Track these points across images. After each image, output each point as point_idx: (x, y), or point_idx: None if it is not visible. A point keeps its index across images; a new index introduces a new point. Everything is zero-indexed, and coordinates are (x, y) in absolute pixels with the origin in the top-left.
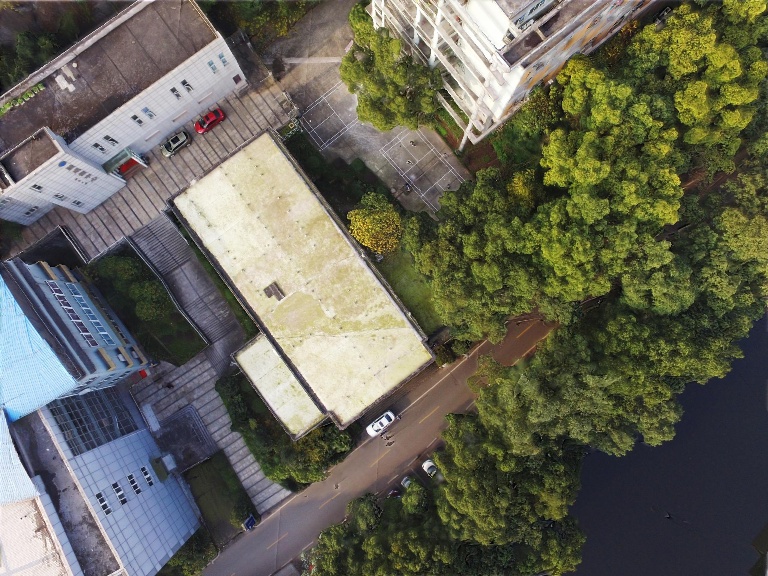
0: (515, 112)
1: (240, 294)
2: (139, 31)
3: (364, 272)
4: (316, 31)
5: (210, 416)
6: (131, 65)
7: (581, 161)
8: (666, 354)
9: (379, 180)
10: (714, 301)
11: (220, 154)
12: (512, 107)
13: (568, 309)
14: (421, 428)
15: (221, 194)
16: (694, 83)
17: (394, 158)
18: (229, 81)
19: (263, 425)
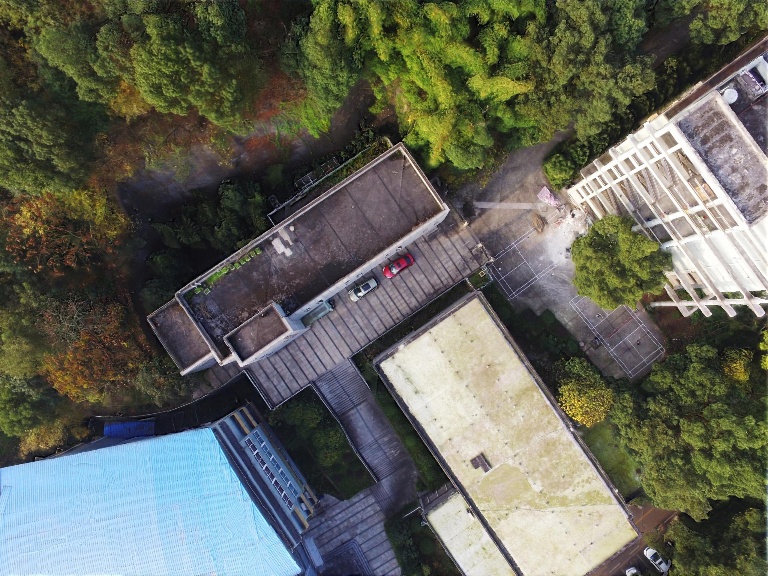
0: None
1: (445, 463)
2: (359, 195)
3: (572, 446)
4: (508, 175)
5: (373, 552)
6: (350, 231)
7: None
8: None
9: (568, 333)
10: None
11: (407, 299)
12: None
13: None
14: None
15: (429, 360)
16: None
17: (584, 310)
18: None
19: (432, 568)
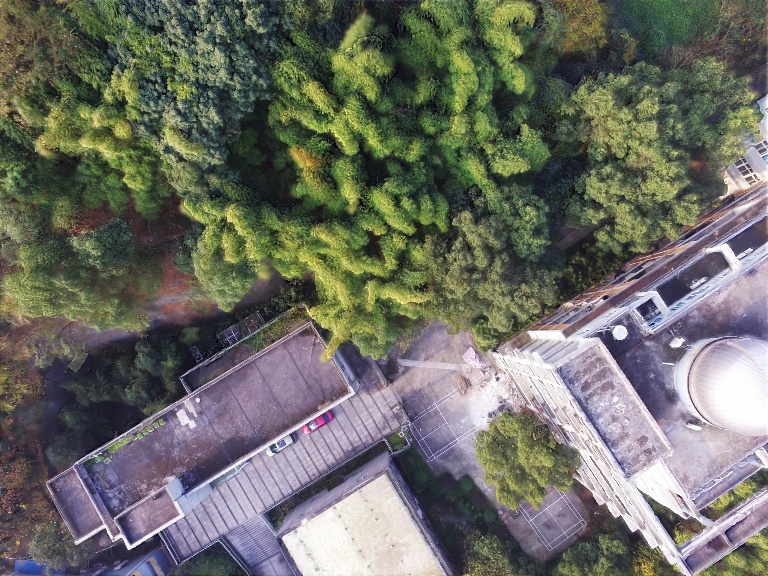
0: None
1: None
2: (267, 370)
3: None
4: (434, 333)
5: None
6: (256, 406)
7: None
8: None
9: (487, 500)
10: None
11: (324, 455)
12: None
13: None
14: None
15: (332, 537)
16: None
17: None
18: None
19: None
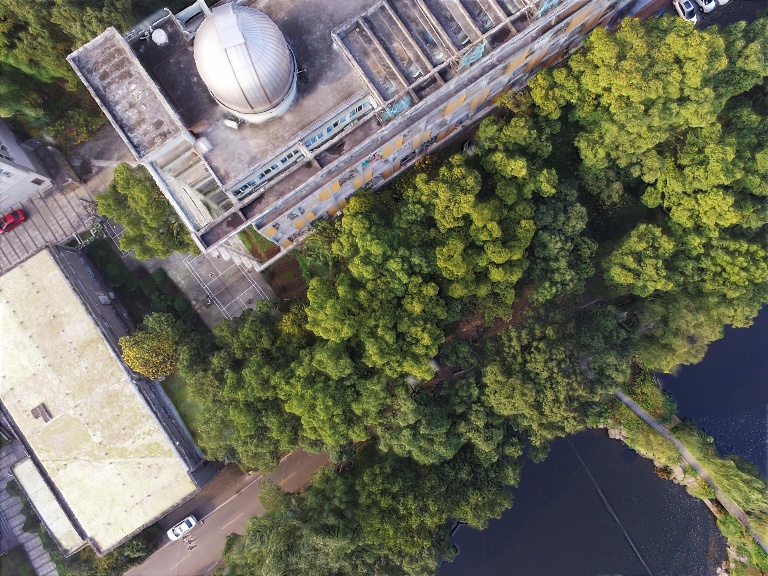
0: (302, 242)
1: (8, 413)
2: None
3: (135, 398)
4: None
5: (12, 510)
6: None
7: (325, 319)
8: (416, 508)
9: (180, 291)
10: (479, 451)
11: (20, 255)
12: (298, 237)
13: (336, 448)
14: (223, 534)
15: None
16: (463, 235)
17: (197, 269)
18: (27, 184)
19: None
